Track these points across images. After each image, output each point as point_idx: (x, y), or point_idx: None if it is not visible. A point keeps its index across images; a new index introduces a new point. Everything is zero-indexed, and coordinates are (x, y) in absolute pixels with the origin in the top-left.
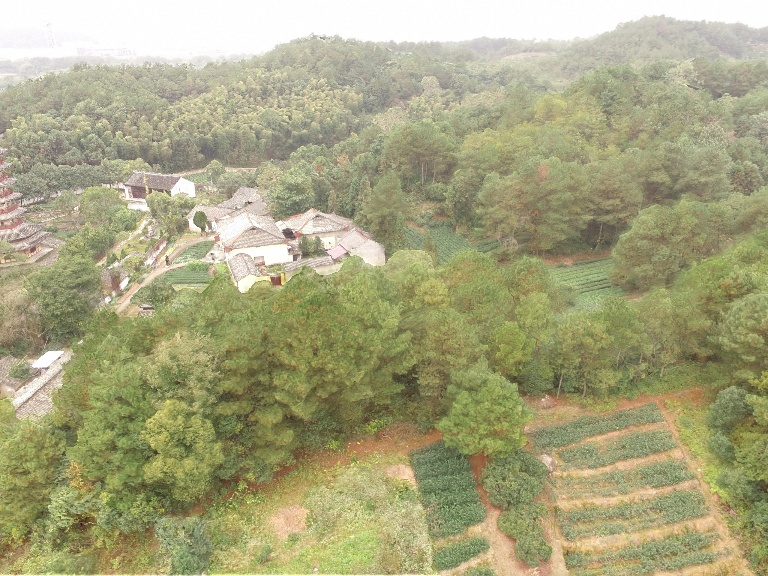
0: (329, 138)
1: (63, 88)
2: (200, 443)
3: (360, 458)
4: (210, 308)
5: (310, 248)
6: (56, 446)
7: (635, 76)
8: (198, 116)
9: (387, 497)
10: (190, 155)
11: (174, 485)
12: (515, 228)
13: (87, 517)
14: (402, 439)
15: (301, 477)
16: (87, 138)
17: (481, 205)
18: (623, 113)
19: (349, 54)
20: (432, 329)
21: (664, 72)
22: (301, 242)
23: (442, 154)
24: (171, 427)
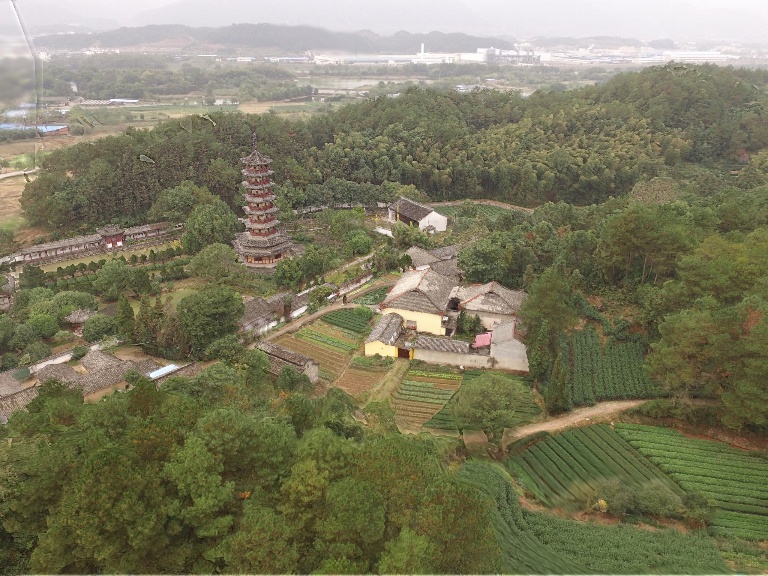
0: (624, 188)
1: None
2: None
3: None
4: (91, 415)
5: (465, 326)
6: None
7: None
8: (490, 148)
9: None
10: (469, 186)
11: None
12: (688, 384)
13: None
14: None
15: None
16: (380, 159)
17: None
18: None
19: (695, 91)
20: (243, 528)
21: None
22: (459, 317)
23: (666, 253)
24: None
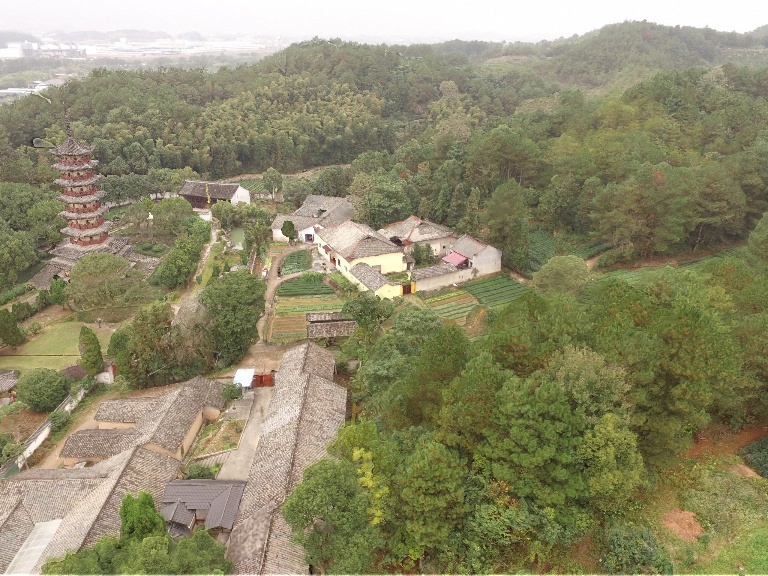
0: (361, 143)
1: (91, 95)
2: (632, 454)
3: (696, 460)
4: (560, 322)
5: (423, 255)
6: (460, 465)
7: (685, 82)
8: (232, 122)
9: (761, 496)
10: (228, 162)
11: (613, 496)
12: (634, 231)
13: (526, 533)
14: (719, 440)
15: (658, 482)
16: (130, 147)
17: (588, 209)
18: (690, 118)
19: (364, 59)
20: (752, 334)
21: (698, 78)
22: (413, 250)
23: (532, 160)
24: (617, 440)
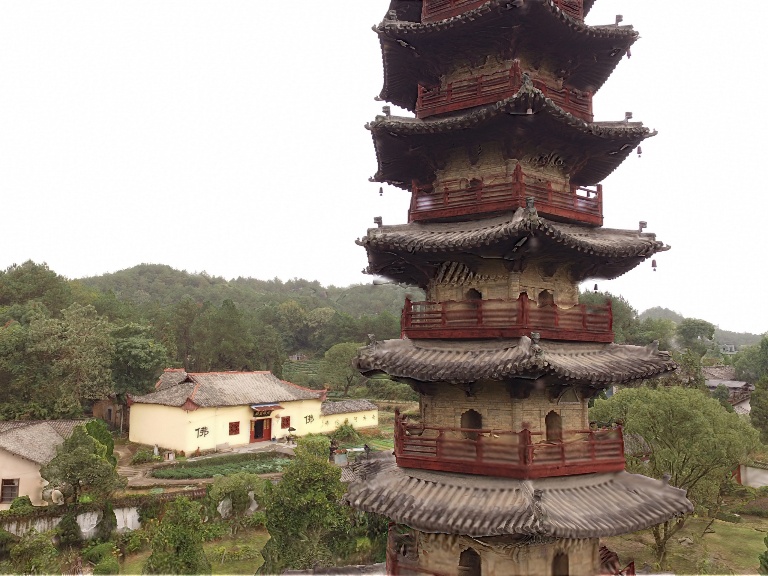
0: None
1: None
2: None
3: None
4: None
5: None
6: None
7: None
8: None
9: None
10: None
11: None
12: None
13: None
14: None
15: None
16: None
17: None
18: None
19: None
20: None
21: None
22: None
23: None
24: None
